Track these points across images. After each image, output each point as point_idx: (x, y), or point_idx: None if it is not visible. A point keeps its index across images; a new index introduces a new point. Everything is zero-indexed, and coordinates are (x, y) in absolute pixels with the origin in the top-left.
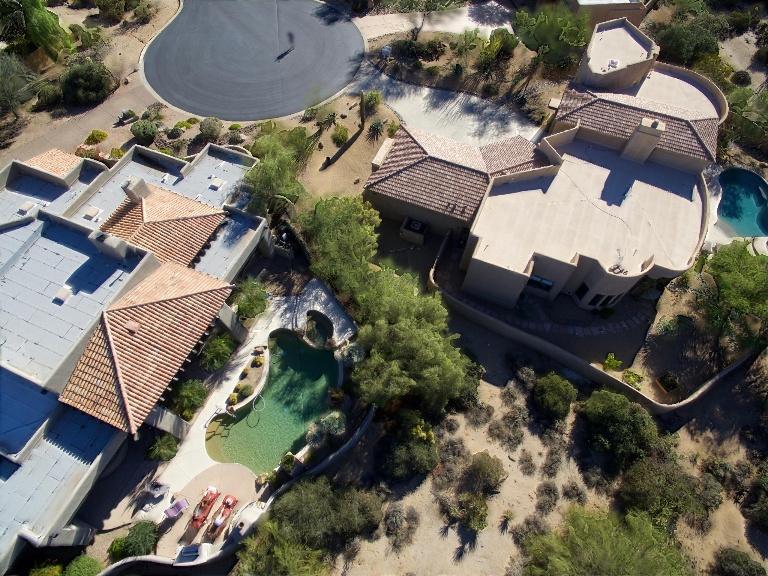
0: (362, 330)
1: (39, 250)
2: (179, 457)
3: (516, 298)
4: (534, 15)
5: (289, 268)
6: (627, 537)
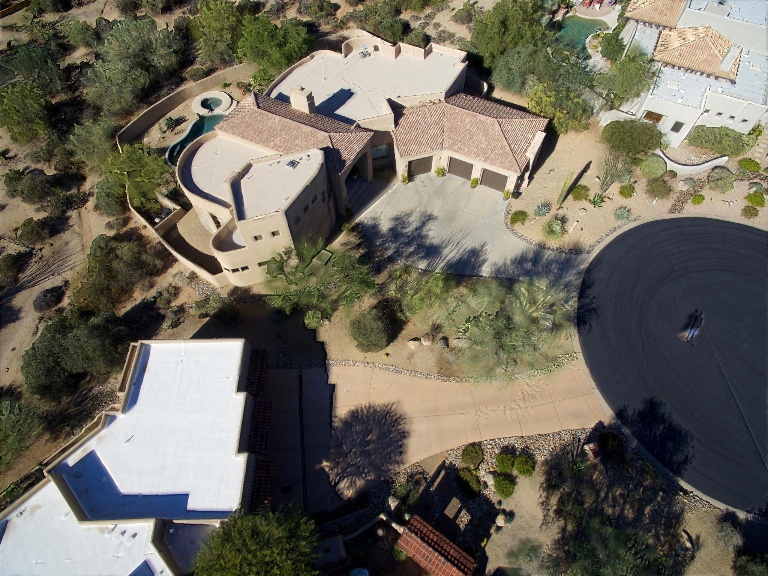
0: (540, 14)
1: (765, 24)
2: None
3: None
4: (280, 451)
5: None
6: None
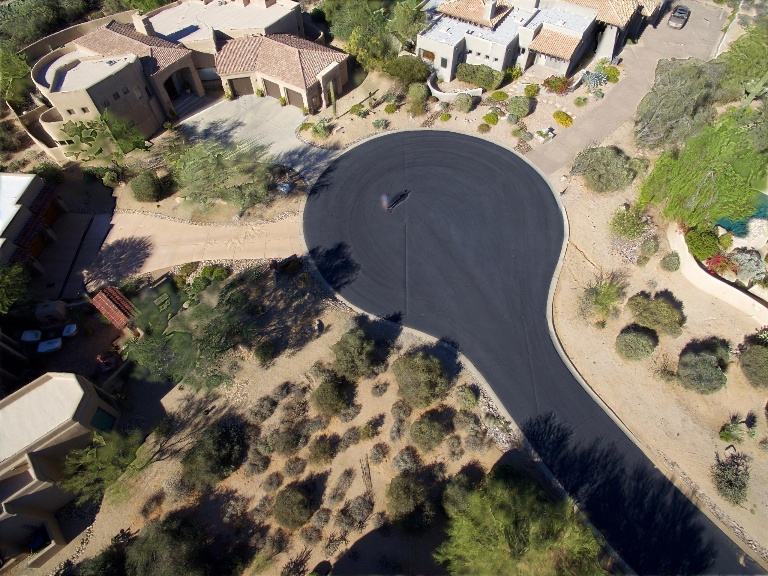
0: None
1: None
2: None
3: None
4: (57, 262)
5: None
6: None
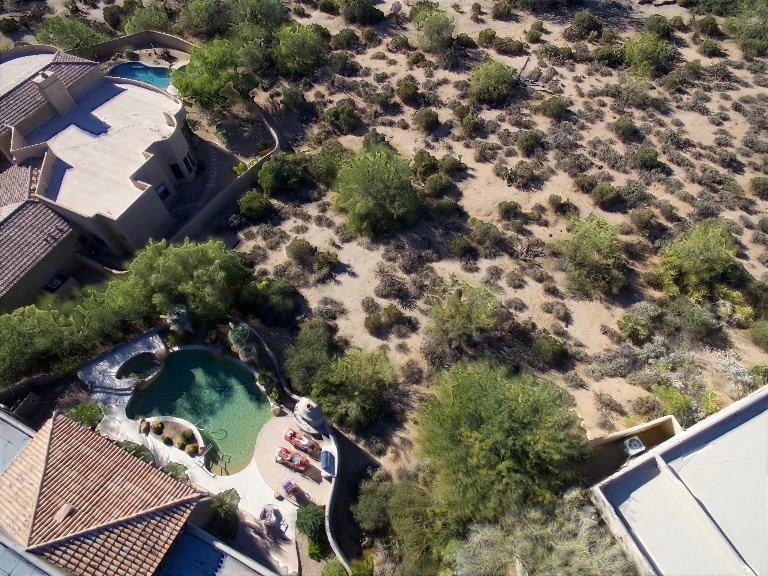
0: (156, 300)
1: None
2: (240, 501)
3: (167, 212)
4: None
5: (52, 404)
6: None
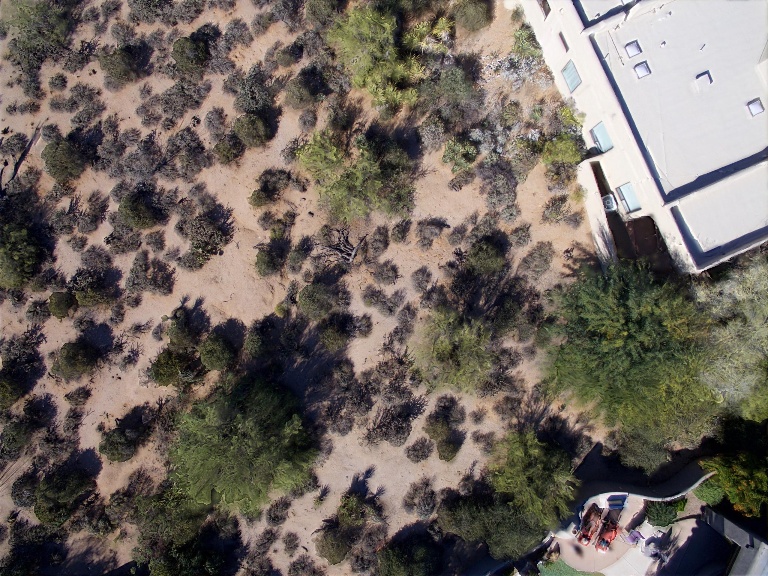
0: None
1: None
2: None
3: None
4: None
5: None
6: None
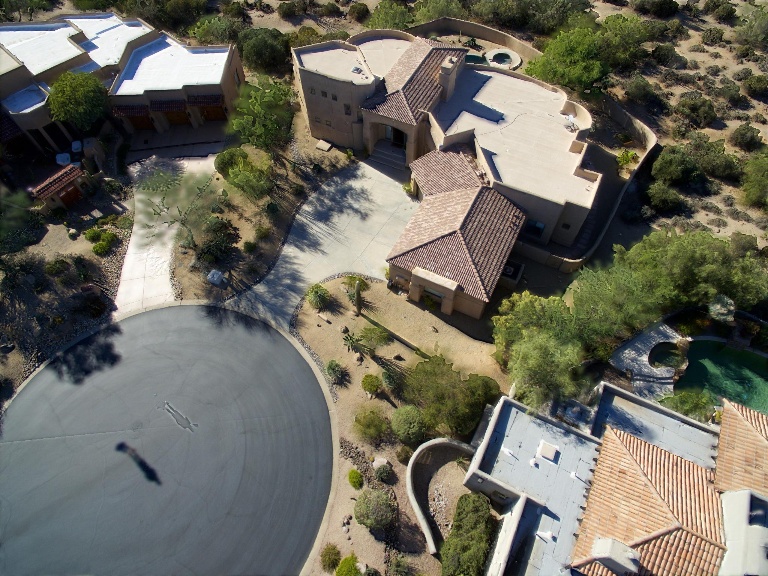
0: (711, 290)
1: None
2: None
3: None
4: (171, 137)
5: None
6: (762, 173)
